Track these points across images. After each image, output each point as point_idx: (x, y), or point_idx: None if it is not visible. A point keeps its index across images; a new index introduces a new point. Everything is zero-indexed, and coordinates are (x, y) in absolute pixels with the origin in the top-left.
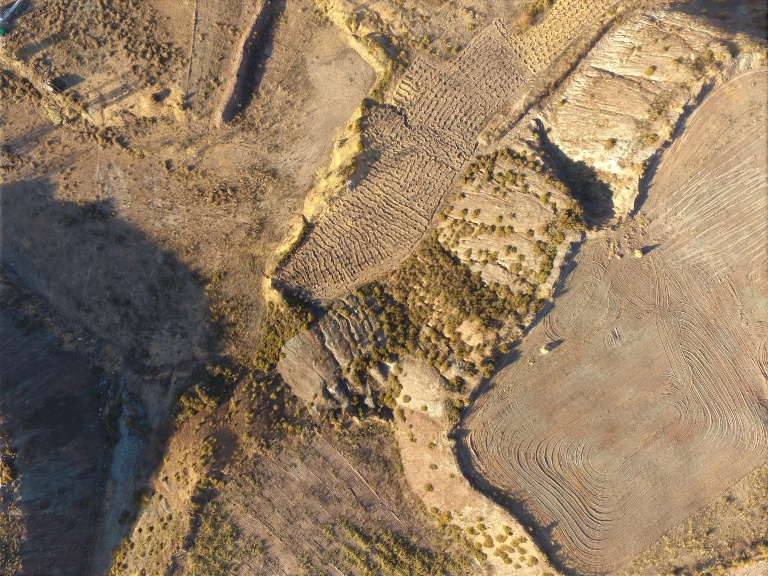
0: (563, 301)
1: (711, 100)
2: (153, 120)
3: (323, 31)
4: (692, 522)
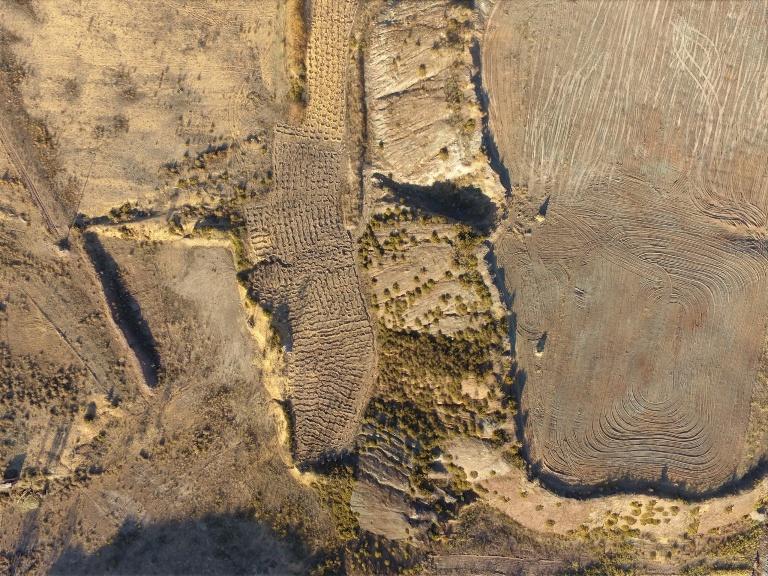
0: (519, 305)
1: (486, 55)
2: (102, 434)
3: (160, 254)
4: (763, 374)
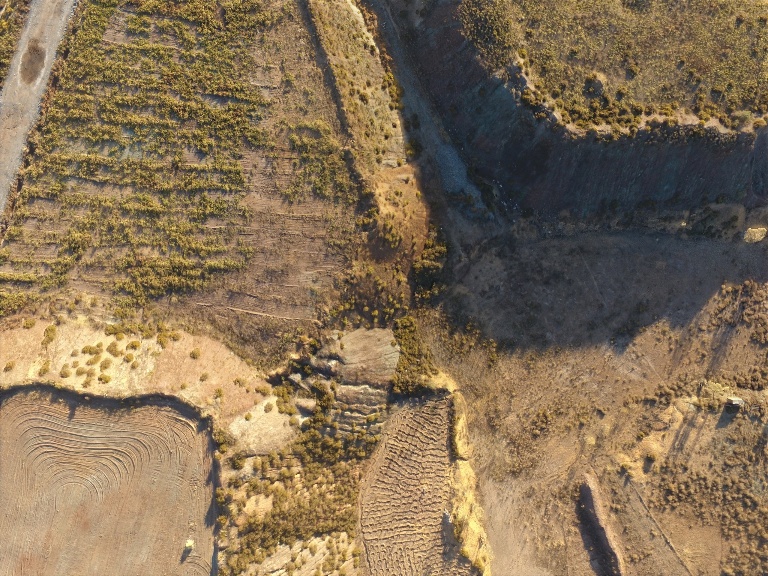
0: None
1: None
2: (640, 438)
3: None
4: None
